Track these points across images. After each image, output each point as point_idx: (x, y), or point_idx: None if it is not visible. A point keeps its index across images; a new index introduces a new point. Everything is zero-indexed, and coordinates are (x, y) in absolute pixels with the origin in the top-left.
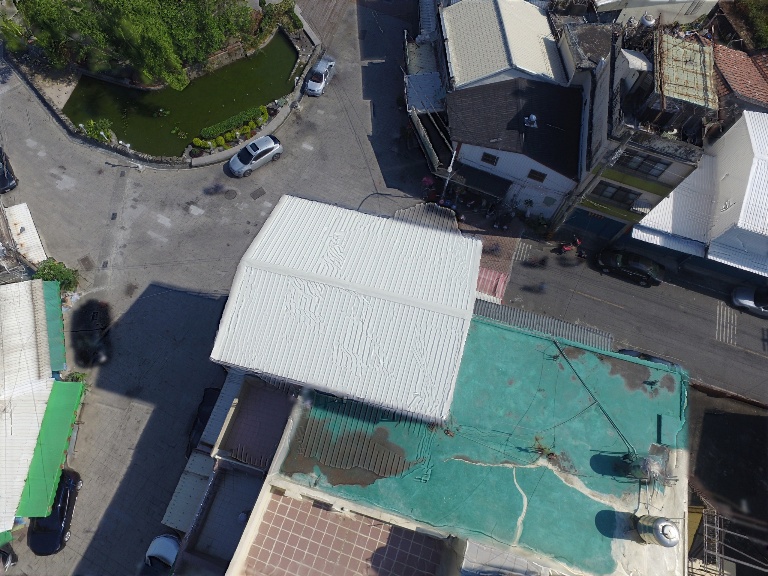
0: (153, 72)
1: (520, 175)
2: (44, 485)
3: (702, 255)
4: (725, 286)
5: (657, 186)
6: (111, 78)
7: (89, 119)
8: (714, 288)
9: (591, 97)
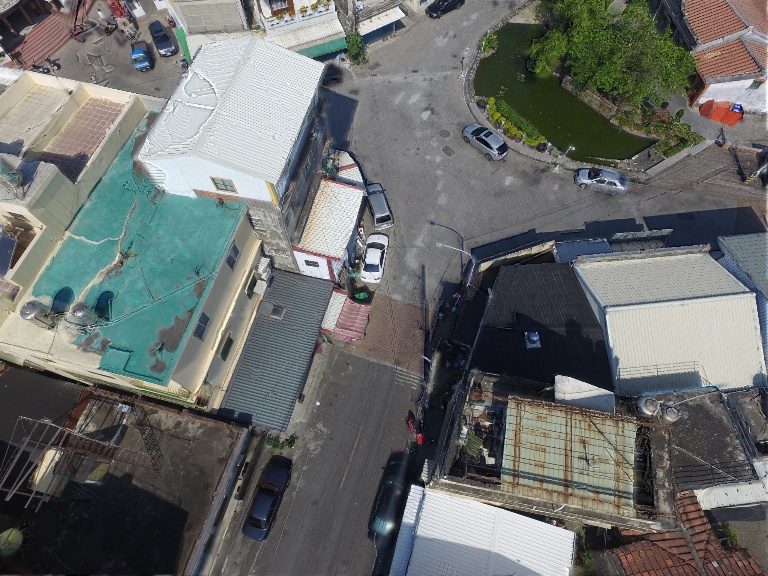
0: None
1: None
2: None
3: None
4: None
5: None
6: None
7: (504, 39)
8: None
9: None
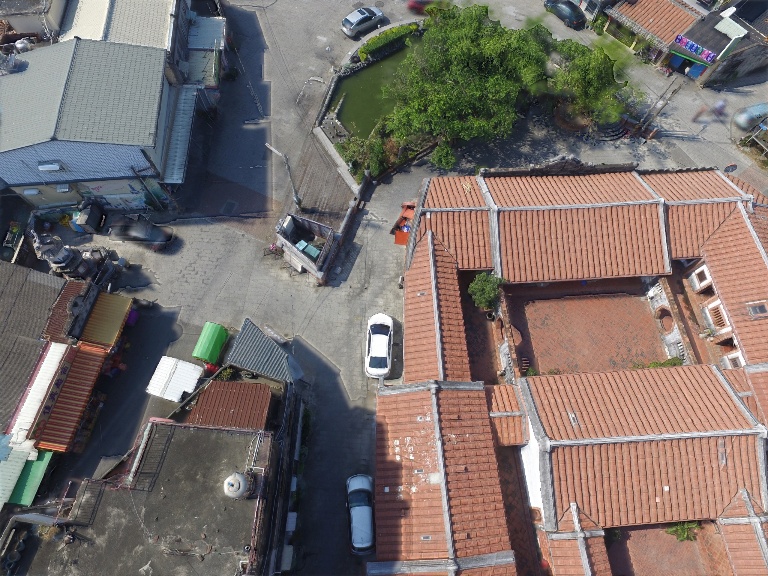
0: None
1: None
2: None
3: None
4: None
5: None
6: None
7: None
8: None
9: None
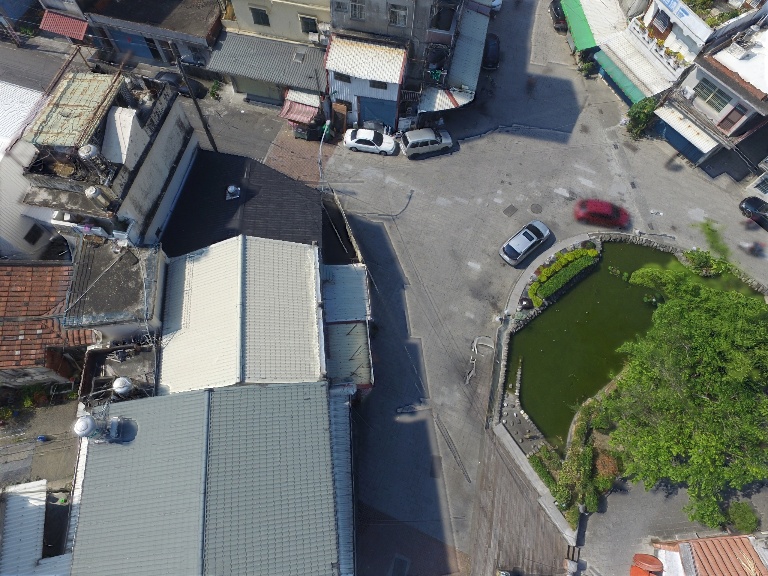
0: None
1: None
2: (571, 7)
3: None
4: None
5: None
6: None
7: (727, 289)
8: None
9: (157, 207)
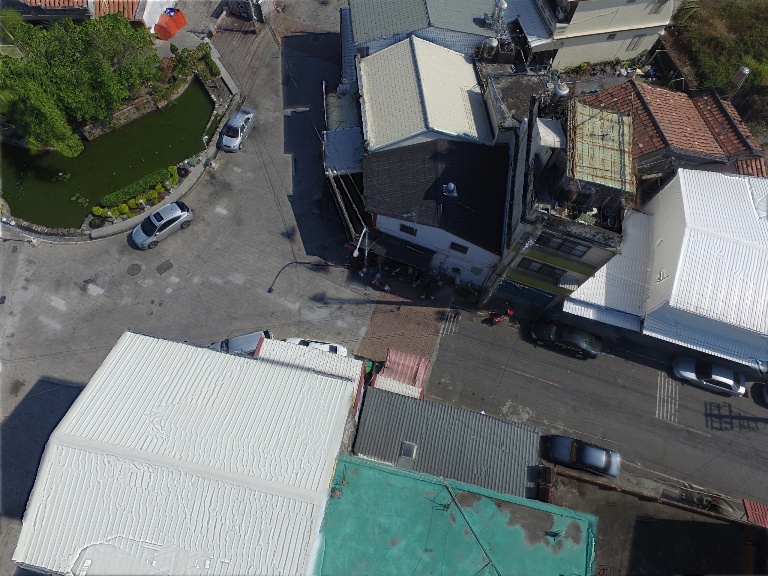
0: (41, 139)
1: (442, 246)
2: None
3: (637, 329)
4: (666, 356)
5: (581, 266)
6: (6, 139)
7: None
8: (655, 357)
9: (514, 161)
